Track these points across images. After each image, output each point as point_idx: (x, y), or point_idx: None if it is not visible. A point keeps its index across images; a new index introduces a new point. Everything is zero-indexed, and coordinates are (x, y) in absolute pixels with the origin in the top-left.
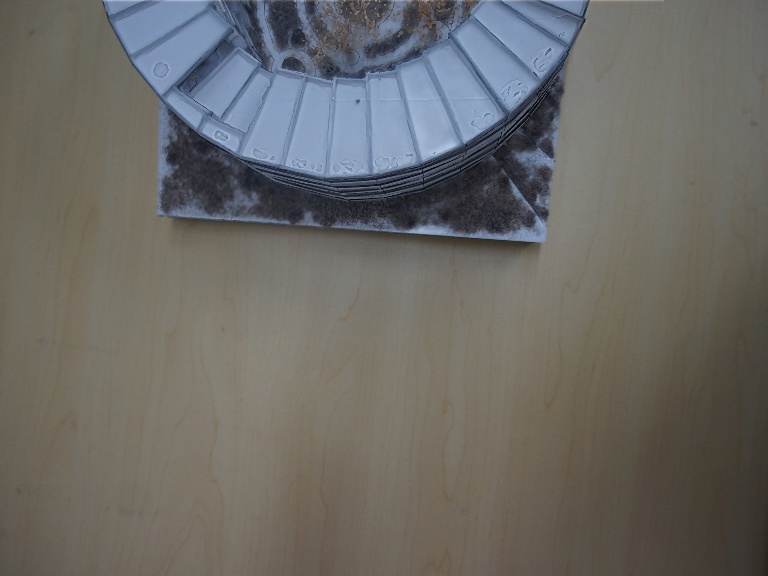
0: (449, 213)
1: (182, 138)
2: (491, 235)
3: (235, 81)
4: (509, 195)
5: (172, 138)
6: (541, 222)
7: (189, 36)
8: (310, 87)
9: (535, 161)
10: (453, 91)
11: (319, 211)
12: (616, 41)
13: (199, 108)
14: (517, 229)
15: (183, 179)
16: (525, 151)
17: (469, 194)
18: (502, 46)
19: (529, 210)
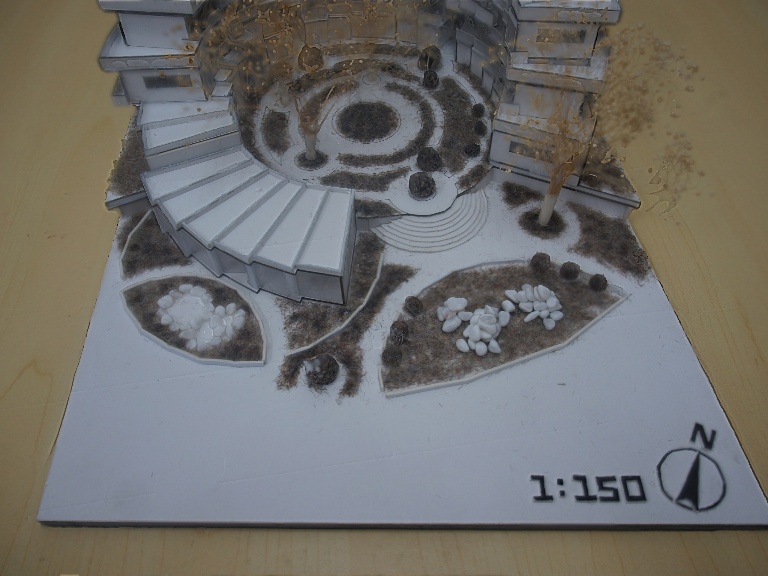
0: None
1: None
2: None
3: None
4: None
5: None
6: None
7: None
8: None
9: None
10: None
11: None
12: (81, 141)
13: None
14: None
15: None
16: None
17: None
18: None
19: None
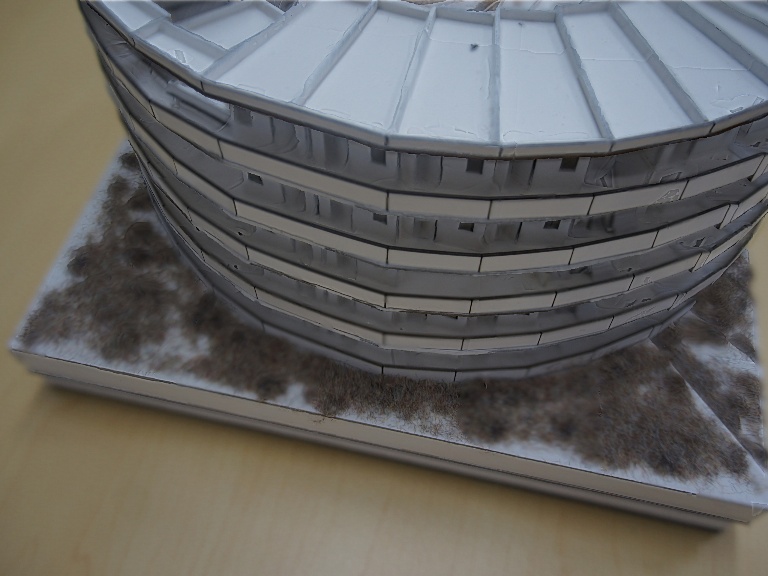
0: (574, 423)
1: (109, 239)
2: (660, 478)
3: (236, 38)
4: (689, 408)
5: (93, 238)
6: (759, 468)
7: None
8: (382, 18)
9: (727, 363)
10: (669, 55)
11: (319, 384)
12: None
13: (152, 8)
14: (712, 474)
15: (83, 298)
16: (706, 345)
17: (611, 395)
18: (752, 19)
19: (732, 441)
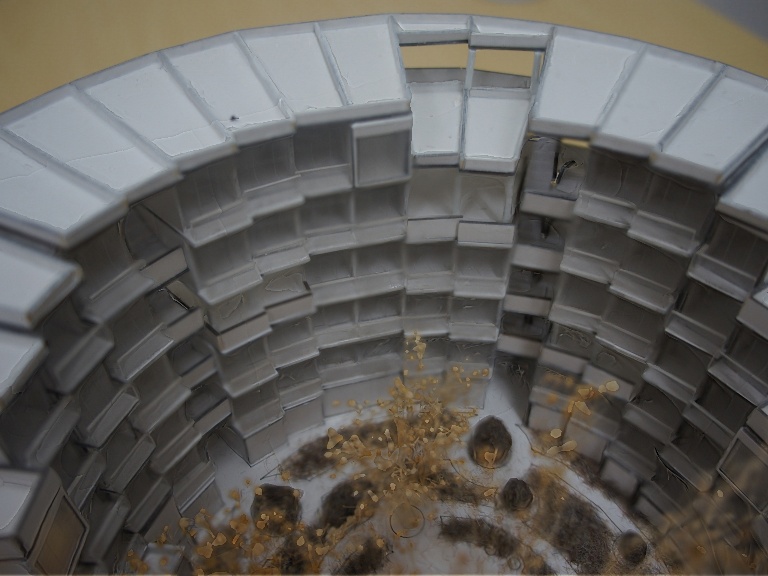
0: None
1: None
2: None
3: (486, 137)
4: None
5: None
6: None
7: (592, 99)
8: None
9: None
10: (37, 182)
11: None
12: None
13: None
14: None
15: None
16: None
17: None
18: None
19: None
